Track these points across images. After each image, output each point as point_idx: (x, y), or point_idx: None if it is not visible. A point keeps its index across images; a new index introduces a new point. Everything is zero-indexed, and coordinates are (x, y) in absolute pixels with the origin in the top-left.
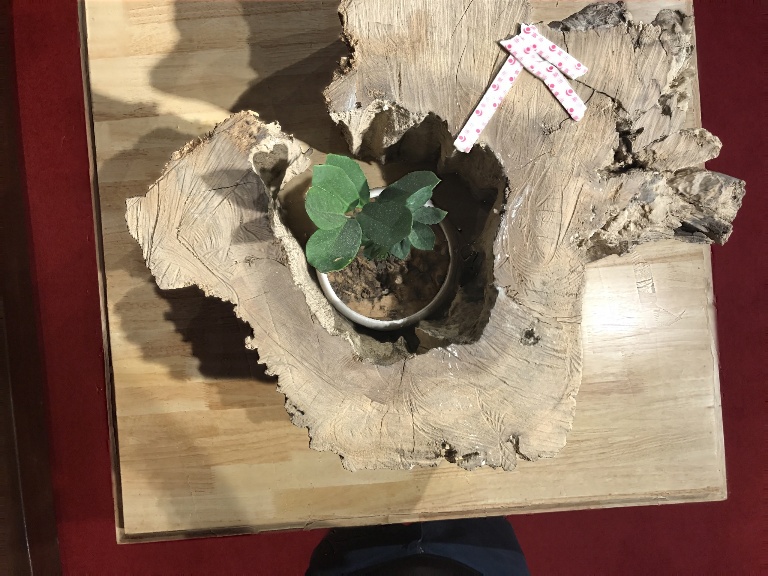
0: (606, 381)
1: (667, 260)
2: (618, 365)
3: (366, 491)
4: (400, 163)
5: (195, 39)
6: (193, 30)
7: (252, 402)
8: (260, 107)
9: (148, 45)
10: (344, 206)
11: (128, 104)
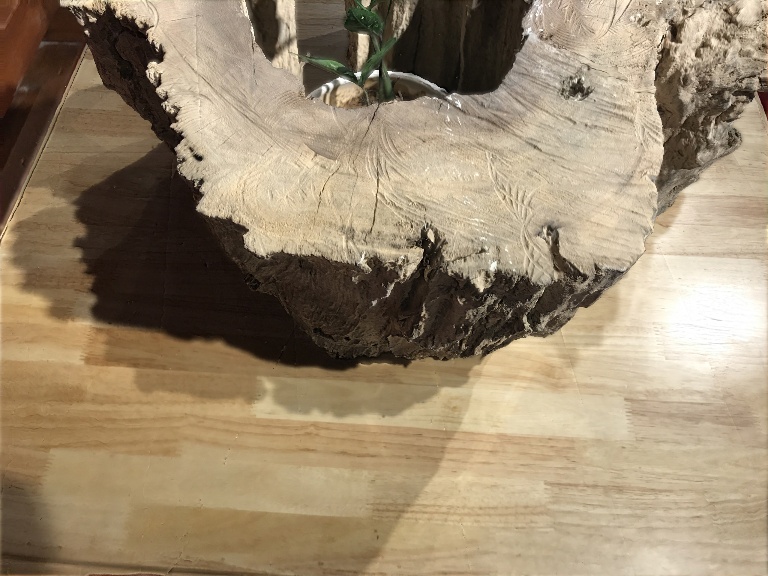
0: (690, 401)
1: (757, 257)
2: (706, 381)
3: (287, 526)
4: None
5: None
6: None
7: (149, 362)
8: None
9: None
10: None
11: None
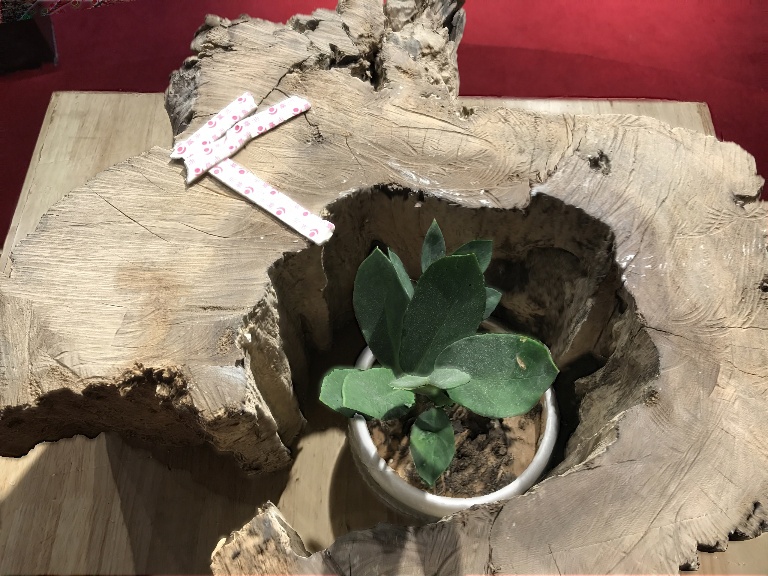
0: None
1: None
2: None
3: None
4: (306, 406)
5: None
6: None
7: None
8: None
9: None
10: (404, 393)
11: None
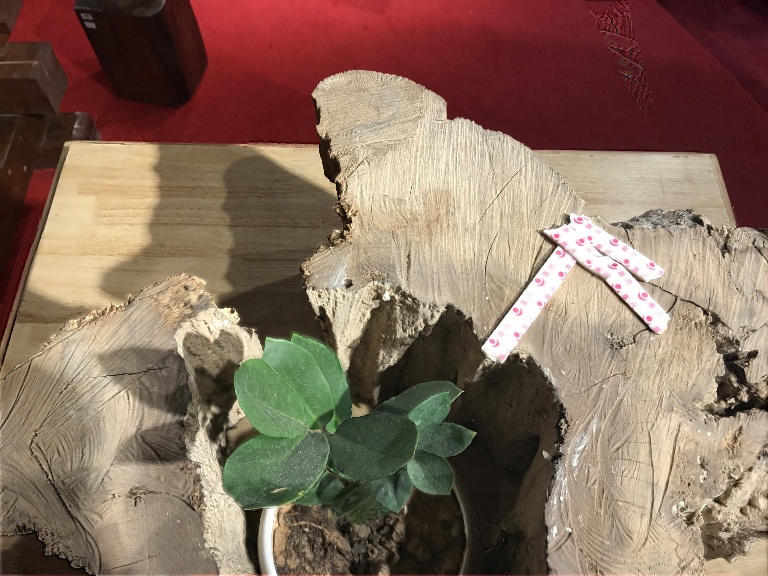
0: None
1: None
2: None
3: None
4: None
5: (168, 244)
6: (168, 236)
7: None
8: None
9: (111, 246)
10: (308, 418)
11: (65, 306)
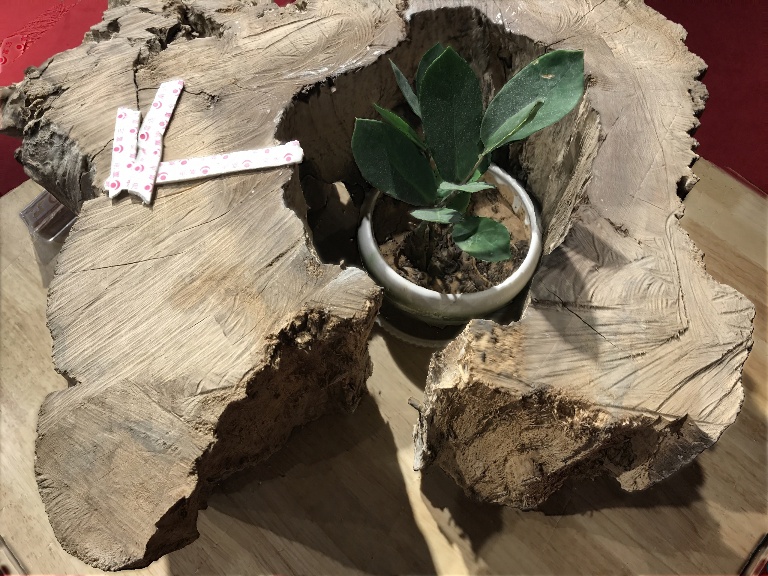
0: None
1: None
2: None
3: None
4: None
5: None
6: None
7: None
8: (403, 548)
9: None
10: None
11: None
